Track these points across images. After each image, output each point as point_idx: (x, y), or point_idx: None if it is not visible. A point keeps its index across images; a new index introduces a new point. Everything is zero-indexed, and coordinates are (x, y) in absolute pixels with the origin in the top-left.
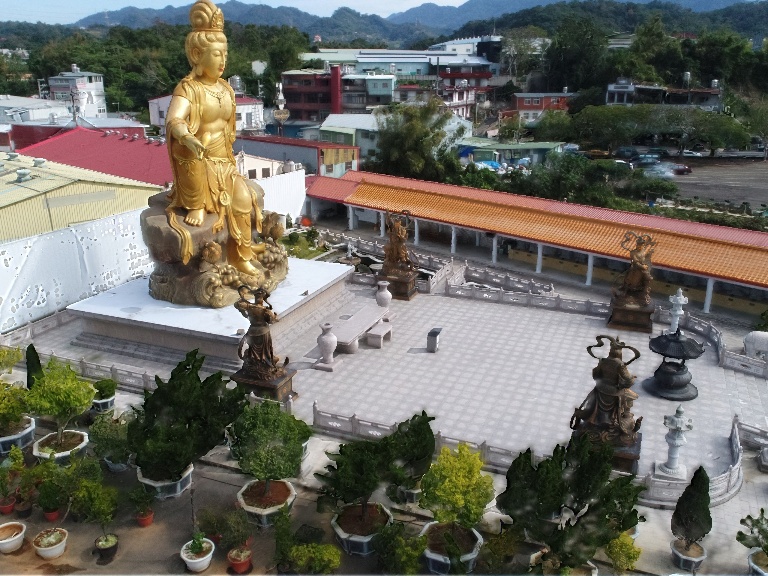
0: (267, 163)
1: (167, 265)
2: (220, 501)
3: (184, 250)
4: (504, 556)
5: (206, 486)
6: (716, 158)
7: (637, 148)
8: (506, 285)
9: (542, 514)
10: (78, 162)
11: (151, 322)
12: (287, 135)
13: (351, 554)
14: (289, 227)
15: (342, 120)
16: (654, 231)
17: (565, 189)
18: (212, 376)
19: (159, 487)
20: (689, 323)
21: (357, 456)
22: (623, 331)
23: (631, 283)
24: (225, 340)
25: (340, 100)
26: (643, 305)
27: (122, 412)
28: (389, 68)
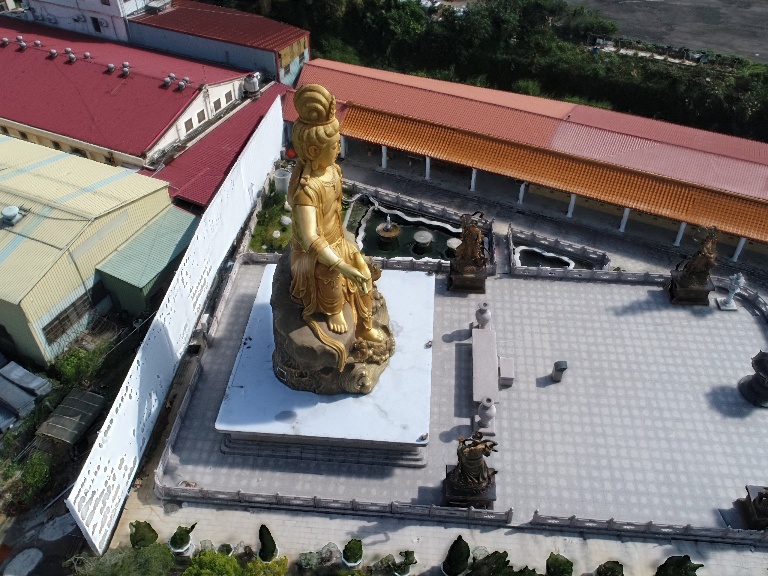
0: (228, 86)
1: None
2: None
3: (341, 363)
4: None
5: None
6: None
7: None
8: (555, 248)
9: None
10: None
11: (325, 436)
12: None
13: None
14: None
15: None
16: (689, 185)
17: (506, 33)
18: (499, 557)
19: None
20: None
21: None
22: (686, 307)
23: (696, 267)
24: None
25: None
26: (704, 284)
27: None
28: None
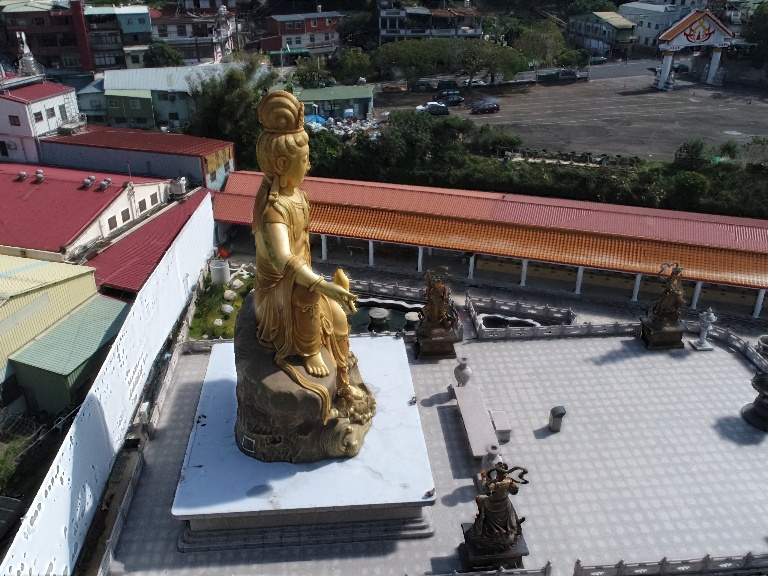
0: (153, 187)
1: None
2: None
3: (326, 411)
4: None
5: None
6: (498, 86)
7: None
8: (517, 312)
9: None
10: None
11: (311, 507)
12: None
13: None
14: None
15: (126, 79)
16: (637, 239)
17: (420, 150)
18: None
19: None
20: None
21: None
22: (663, 351)
23: (666, 307)
24: None
25: (87, 41)
26: (677, 325)
27: None
28: None
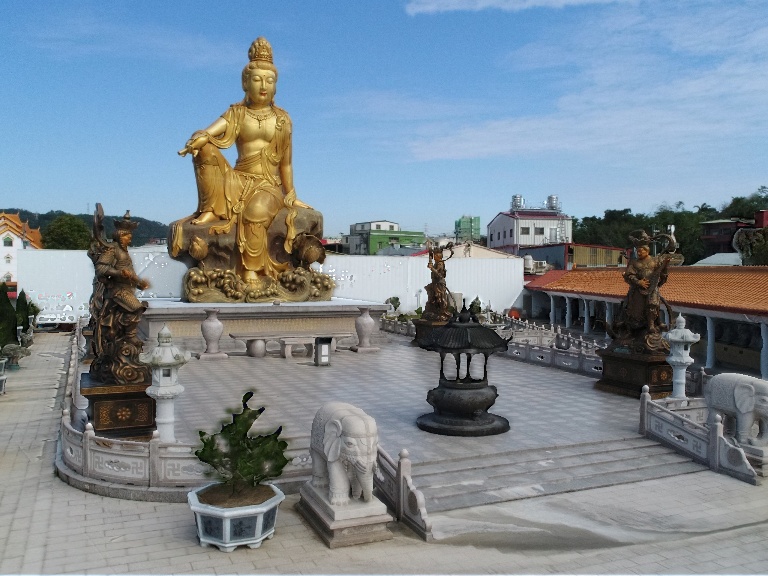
0: (501, 256)
1: None
2: None
3: (174, 242)
4: None
5: None
6: None
7: None
8: None
9: None
10: None
11: None
12: None
13: None
14: None
15: (725, 258)
16: None
17: None
18: None
19: None
20: None
21: None
22: (606, 393)
23: (631, 315)
24: None
25: None
26: (641, 351)
27: None
28: None
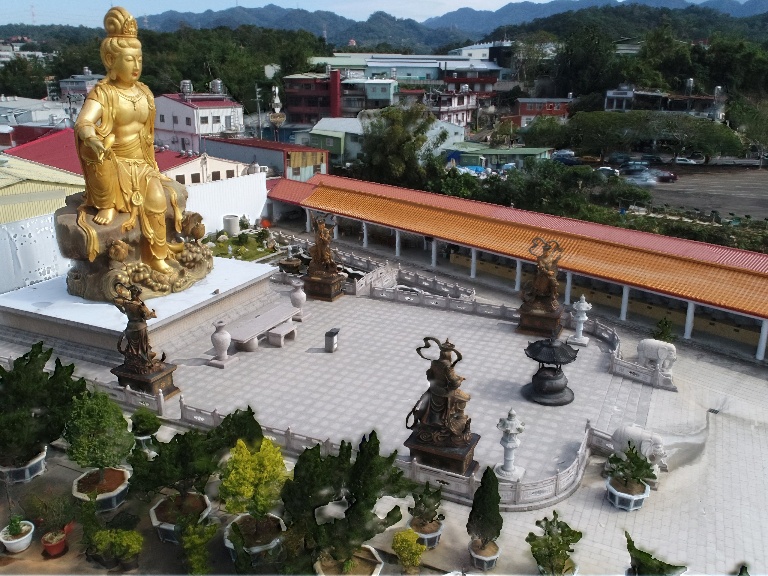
0: (232, 165)
1: (80, 262)
2: (65, 488)
3: (89, 248)
4: (305, 548)
5: (58, 473)
6: (710, 166)
7: (635, 155)
8: (434, 289)
9: (314, 507)
10: (56, 162)
11: (55, 316)
12: (287, 138)
13: (165, 541)
14: (245, 228)
15: (333, 124)
16: (578, 237)
17: (540, 195)
18: None
19: (7, 472)
20: (597, 330)
21: None
22: (530, 336)
23: (539, 289)
24: (118, 335)
25: (339, 104)
26: (550, 311)
27: None
28: (390, 73)
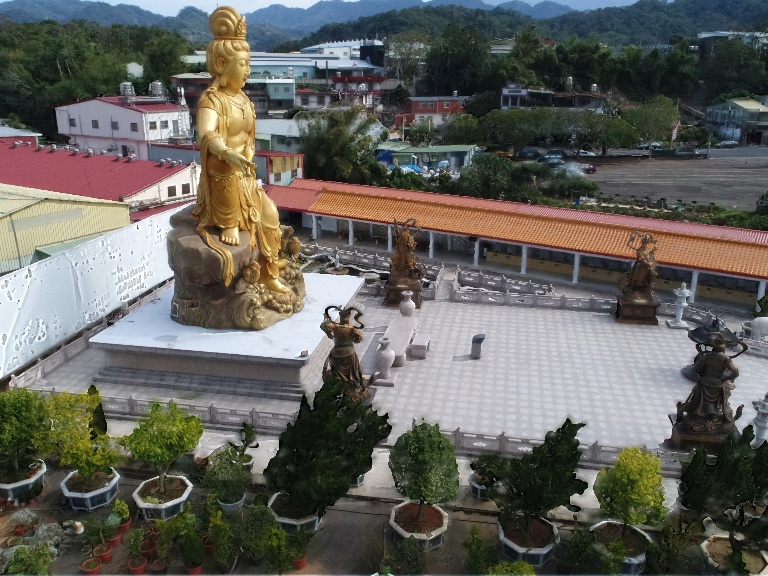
0: None
1: (197, 288)
2: (361, 532)
3: (226, 271)
4: None
5: (338, 518)
6: (608, 157)
7: None
8: (502, 287)
9: None
10: None
11: (198, 350)
12: None
13: None
14: None
15: None
16: (636, 229)
17: (495, 190)
18: None
19: None
20: (687, 313)
21: (541, 470)
22: (633, 325)
23: (637, 279)
24: (288, 363)
25: None
26: (649, 299)
27: (200, 450)
28: (287, 72)
